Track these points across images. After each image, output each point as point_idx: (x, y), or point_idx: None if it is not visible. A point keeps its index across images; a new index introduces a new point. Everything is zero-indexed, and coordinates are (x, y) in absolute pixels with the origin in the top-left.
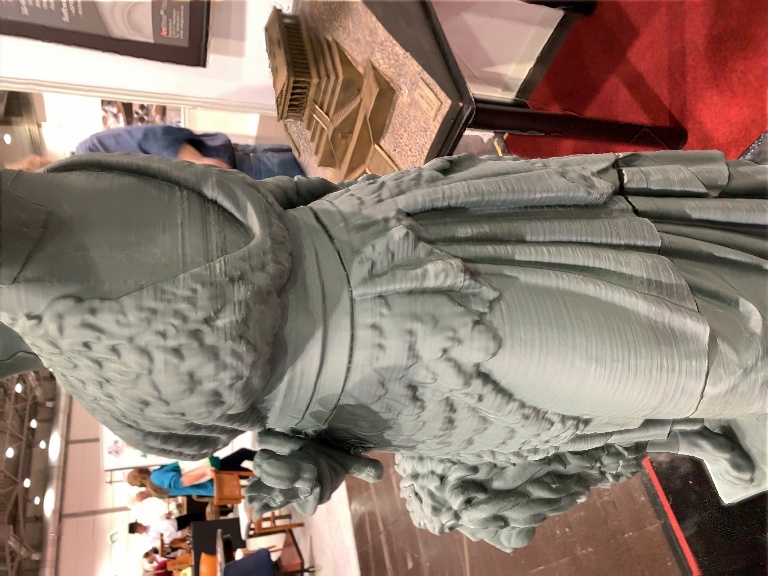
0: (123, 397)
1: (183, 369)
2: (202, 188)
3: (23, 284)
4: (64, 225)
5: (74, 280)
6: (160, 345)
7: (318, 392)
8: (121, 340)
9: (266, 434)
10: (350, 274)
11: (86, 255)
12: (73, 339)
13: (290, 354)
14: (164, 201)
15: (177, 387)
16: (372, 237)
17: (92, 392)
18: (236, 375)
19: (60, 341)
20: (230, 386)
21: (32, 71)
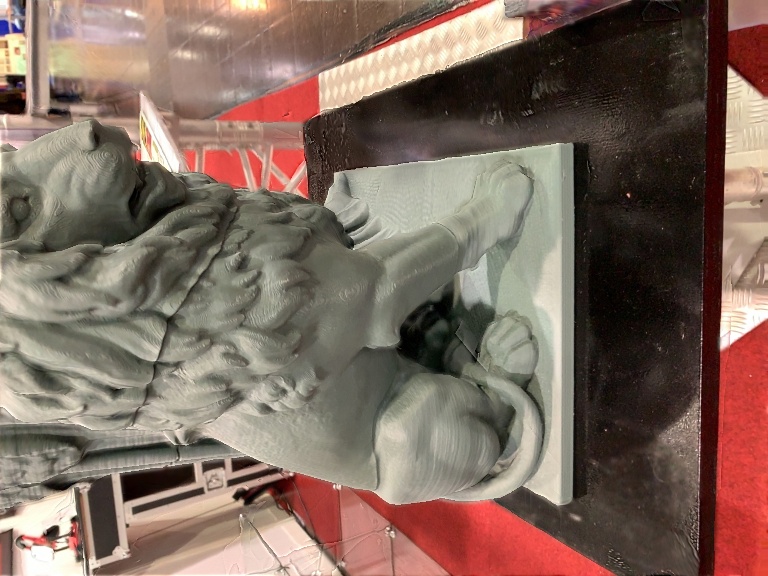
0: None
1: None
2: None
3: None
4: None
5: None
6: None
7: None
8: None
9: None
10: None
11: None
12: None
13: None
14: None
15: None
16: None
17: None
18: None
19: None
20: None
21: None
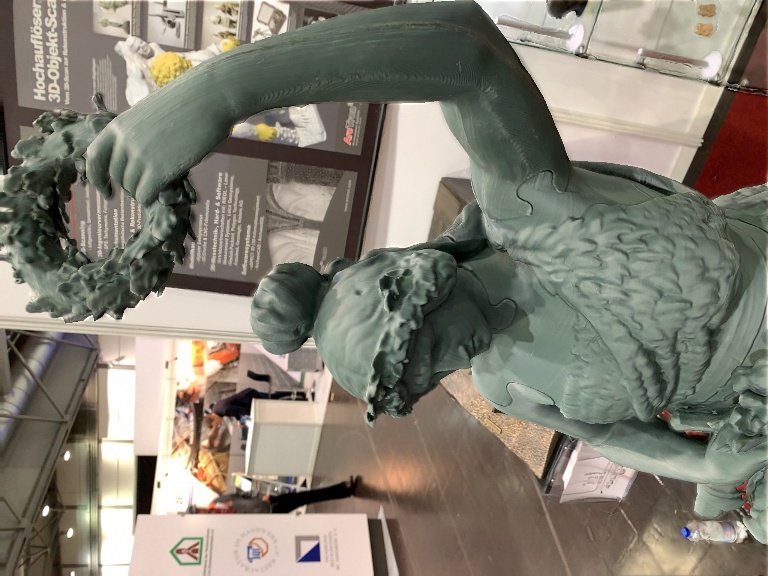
0: (644, 286)
1: (698, 254)
2: (633, 173)
3: (571, 193)
4: (574, 170)
5: (598, 197)
6: (679, 233)
7: (765, 322)
8: (649, 230)
9: (683, 412)
10: (763, 227)
11: (593, 190)
12: (611, 231)
13: (745, 277)
14: (613, 177)
15: (694, 270)
16: (763, 209)
17: (607, 294)
18: (732, 267)
19: (598, 236)
20: (727, 278)
21: (201, 321)
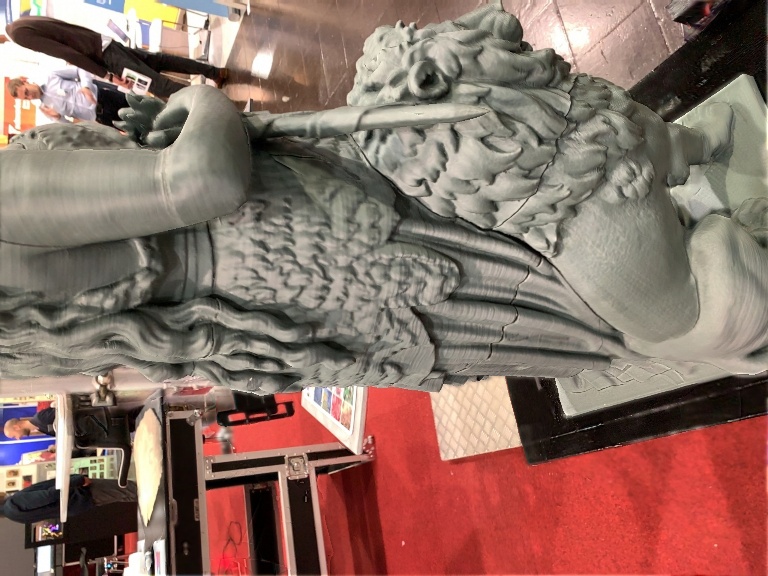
0: None
1: None
2: None
3: None
4: None
5: None
6: None
7: None
8: None
9: None
10: None
11: None
12: None
13: None
14: None
15: None
16: None
17: None
18: None
19: None
20: None
21: None
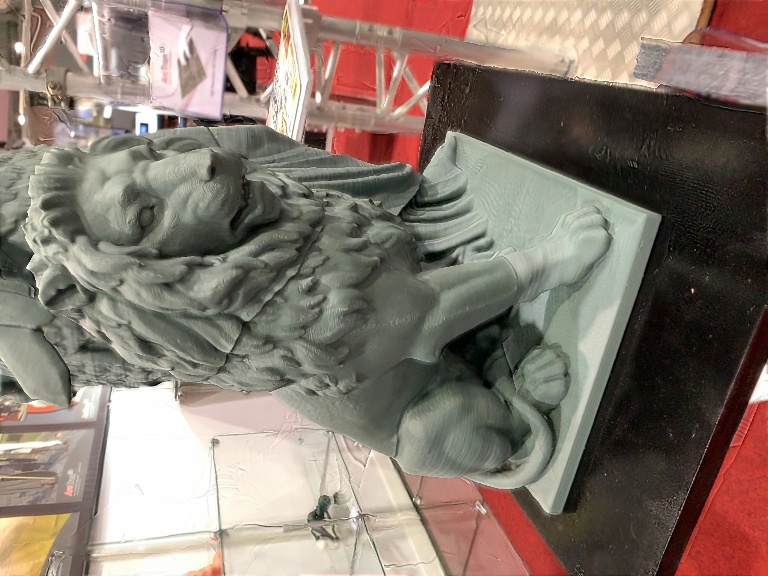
0: None
1: None
2: None
3: None
4: None
5: None
6: None
7: None
8: None
9: None
10: None
11: None
12: None
13: None
14: None
15: None
16: None
17: None
18: None
19: None
20: None
21: None
